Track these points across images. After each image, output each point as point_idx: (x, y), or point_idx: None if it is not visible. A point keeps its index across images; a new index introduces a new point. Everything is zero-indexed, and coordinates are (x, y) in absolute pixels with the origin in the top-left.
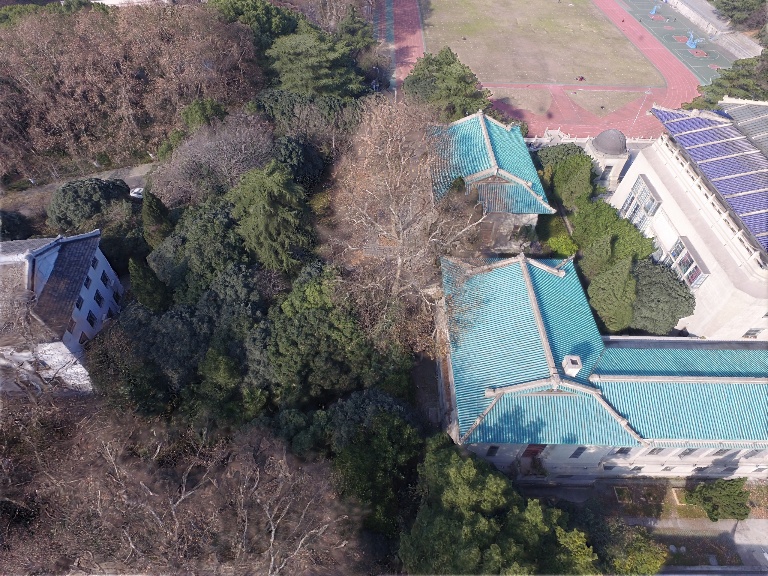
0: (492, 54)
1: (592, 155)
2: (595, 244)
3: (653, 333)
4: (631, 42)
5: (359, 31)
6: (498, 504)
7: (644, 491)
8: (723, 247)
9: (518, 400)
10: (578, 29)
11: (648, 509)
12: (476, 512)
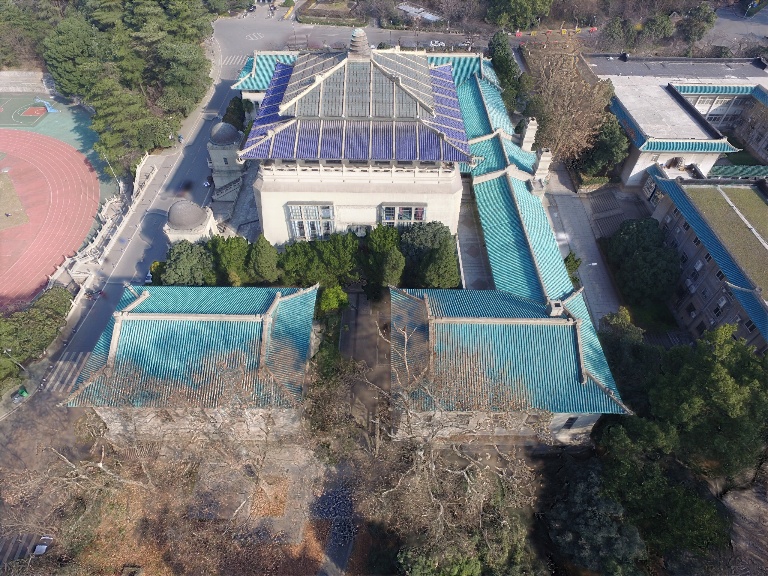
0: None
1: (192, 237)
2: (391, 262)
3: None
4: None
5: None
6: None
7: None
8: (415, 184)
9: None
10: None
11: None
12: None
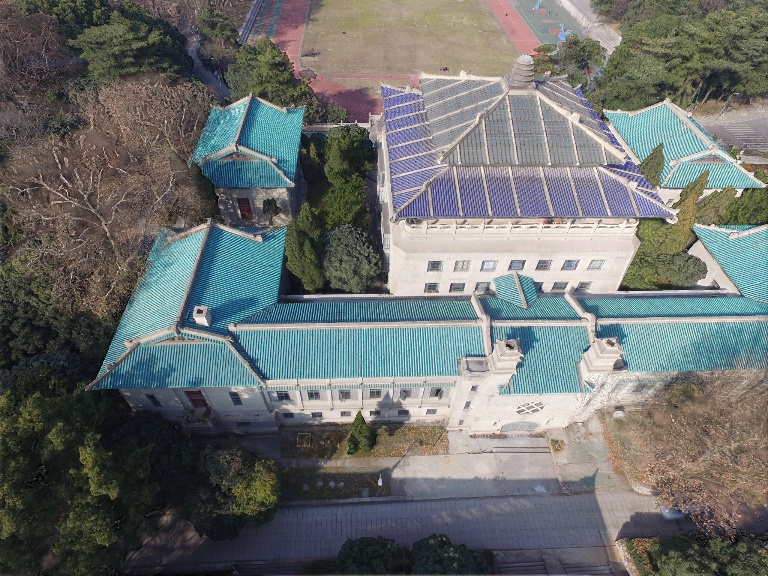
0: (366, 47)
1: None
2: None
3: (348, 292)
4: (506, 35)
5: (218, 25)
6: (33, 430)
7: (325, 436)
8: None
9: (153, 349)
10: (459, 23)
11: (323, 451)
12: (4, 437)
